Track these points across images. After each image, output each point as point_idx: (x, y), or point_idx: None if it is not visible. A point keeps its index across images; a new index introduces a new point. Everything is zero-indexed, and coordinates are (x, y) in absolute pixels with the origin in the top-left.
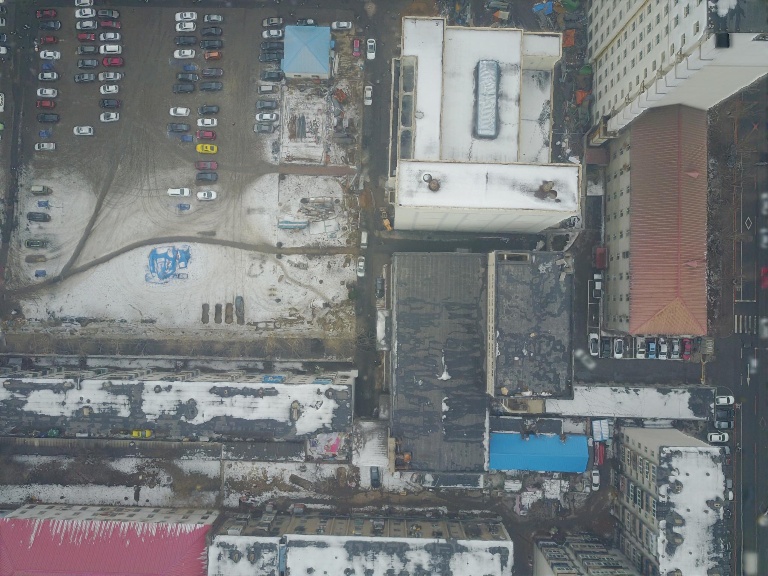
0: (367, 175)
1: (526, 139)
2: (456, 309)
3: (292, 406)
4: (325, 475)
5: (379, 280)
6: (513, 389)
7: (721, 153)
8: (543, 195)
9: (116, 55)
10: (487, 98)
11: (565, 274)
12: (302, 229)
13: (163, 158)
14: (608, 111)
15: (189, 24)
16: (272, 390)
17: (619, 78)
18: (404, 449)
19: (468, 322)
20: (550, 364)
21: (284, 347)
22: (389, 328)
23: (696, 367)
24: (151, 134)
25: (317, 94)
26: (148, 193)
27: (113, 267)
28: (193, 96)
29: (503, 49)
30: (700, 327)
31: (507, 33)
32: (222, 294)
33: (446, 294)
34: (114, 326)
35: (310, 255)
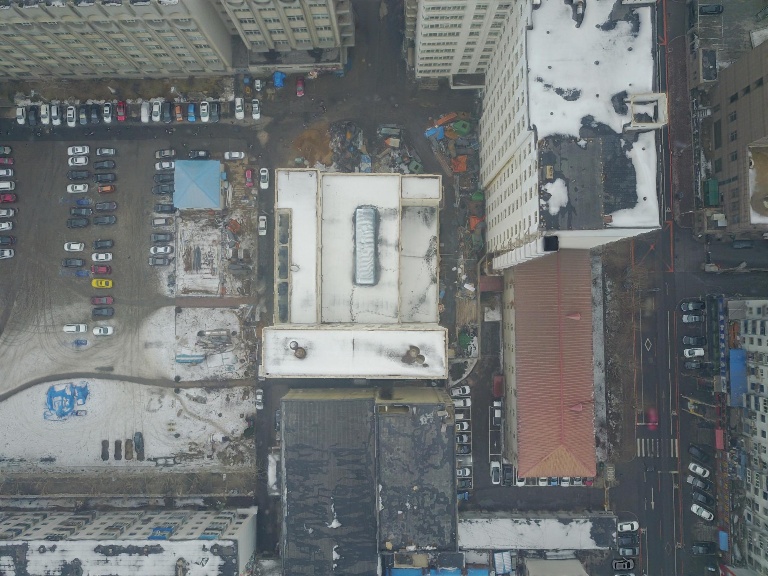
0: (264, 306)
1: (413, 276)
2: (344, 455)
3: (177, 564)
4: None
5: (278, 413)
6: (398, 543)
7: (618, 275)
8: (411, 360)
9: (9, 191)
10: (365, 246)
11: (446, 426)
12: (199, 363)
13: (59, 294)
14: (494, 247)
15: (81, 159)
16: (157, 547)
17: (498, 220)
18: None
19: (357, 468)
20: (434, 517)
21: (185, 482)
22: (280, 472)
23: (600, 492)
24: (46, 270)
25: (212, 225)
26: (45, 329)
27: (11, 405)
28: (88, 230)
29: (382, 193)
30: (588, 470)
31: (385, 177)
32: (121, 430)
33: (334, 440)
34: (13, 466)
35: (209, 388)
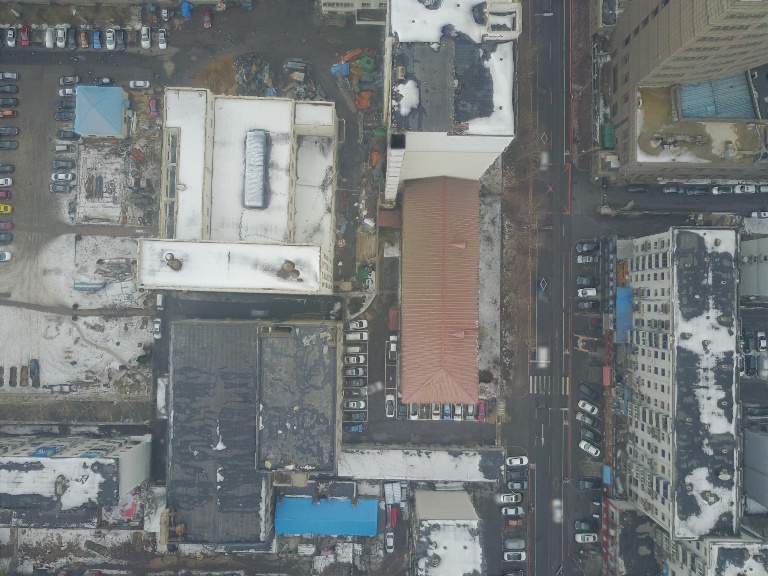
0: None
1: (308, 205)
2: (232, 378)
3: (57, 481)
4: (121, 540)
5: None
6: (276, 463)
7: None
8: (286, 275)
9: None
10: (254, 169)
11: (327, 347)
12: (97, 291)
13: None
14: None
15: None
16: (37, 464)
17: None
18: (179, 520)
19: (244, 391)
20: (313, 437)
21: (80, 410)
22: None
23: (492, 428)
24: None
25: (115, 154)
26: None
27: None
28: None
29: (274, 118)
30: (470, 396)
31: (278, 102)
32: (17, 357)
33: (221, 363)
34: None
35: (107, 317)
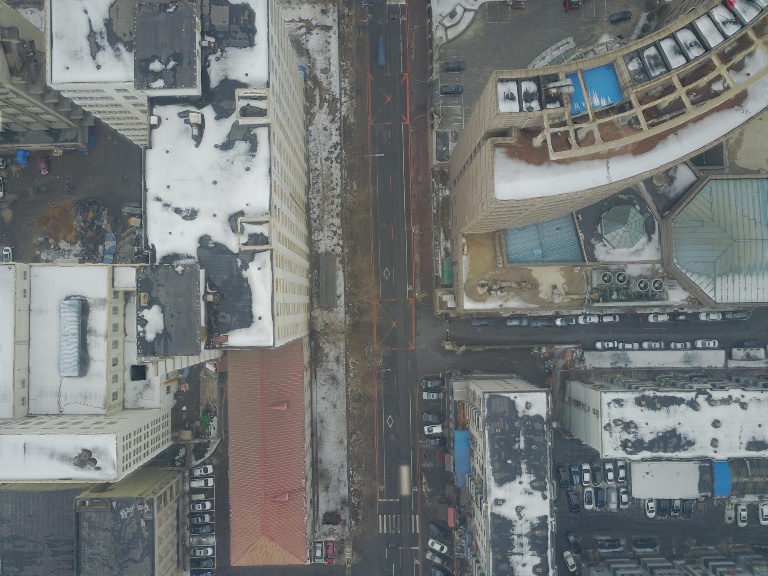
0: None
1: None
2: (59, 546)
3: None
4: None
5: None
6: None
7: (359, 353)
8: (83, 463)
9: None
10: (68, 339)
11: (144, 521)
12: None
13: None
14: None
15: None
16: None
17: None
18: None
19: (72, 558)
20: None
21: None
22: None
23: (342, 569)
24: None
25: None
26: None
27: None
28: None
29: (91, 284)
30: (297, 558)
31: (94, 268)
32: None
33: (48, 531)
34: None
35: None
